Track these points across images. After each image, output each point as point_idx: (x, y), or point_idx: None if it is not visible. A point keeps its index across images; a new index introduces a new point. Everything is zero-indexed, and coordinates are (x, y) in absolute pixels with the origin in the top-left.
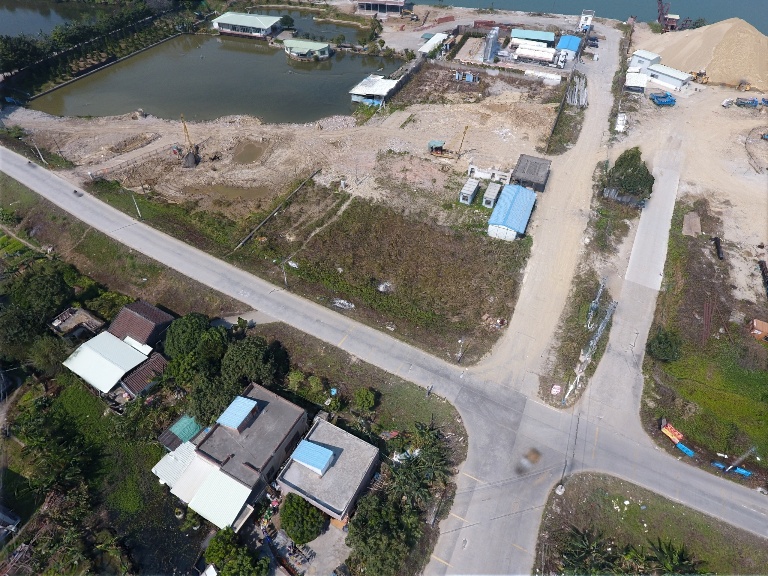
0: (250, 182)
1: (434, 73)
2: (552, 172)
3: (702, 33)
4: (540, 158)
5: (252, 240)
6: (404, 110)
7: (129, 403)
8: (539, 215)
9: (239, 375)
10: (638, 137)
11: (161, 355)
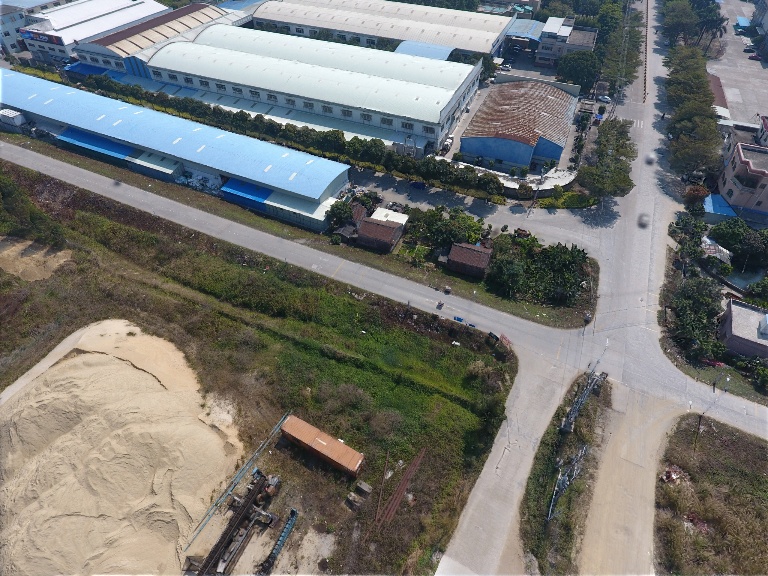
0: None
1: None
2: None
3: None
4: None
5: None
6: None
7: None
8: None
9: None
10: None
11: None
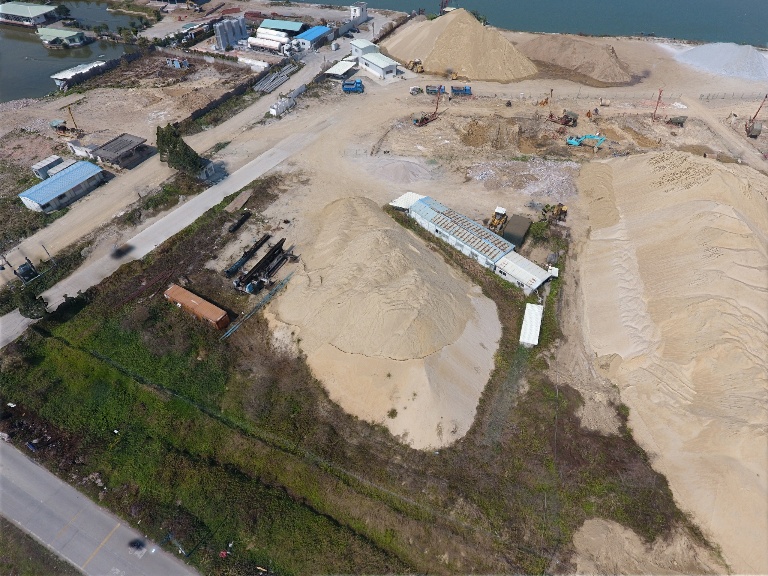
0: None
1: (154, 60)
2: None
3: (432, 24)
4: (138, 137)
5: None
6: (81, 93)
7: None
8: (101, 190)
9: None
10: (289, 121)
11: None
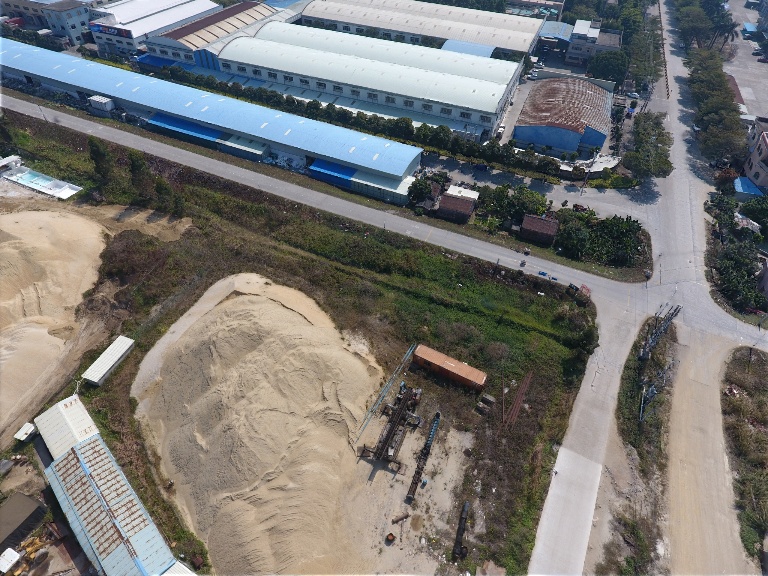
0: None
1: None
2: None
3: None
4: None
5: None
6: None
7: None
8: None
9: None
10: None
11: None
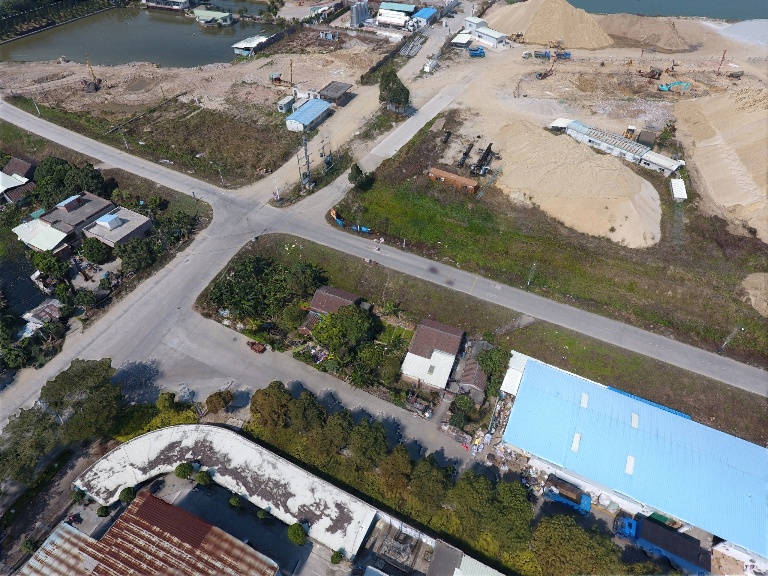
0: (133, 101)
1: (306, 34)
2: (358, 95)
3: (527, 4)
4: (345, 83)
5: (118, 130)
6: (268, 57)
7: (7, 204)
8: (332, 119)
9: (75, 185)
10: (440, 76)
11: (33, 182)
